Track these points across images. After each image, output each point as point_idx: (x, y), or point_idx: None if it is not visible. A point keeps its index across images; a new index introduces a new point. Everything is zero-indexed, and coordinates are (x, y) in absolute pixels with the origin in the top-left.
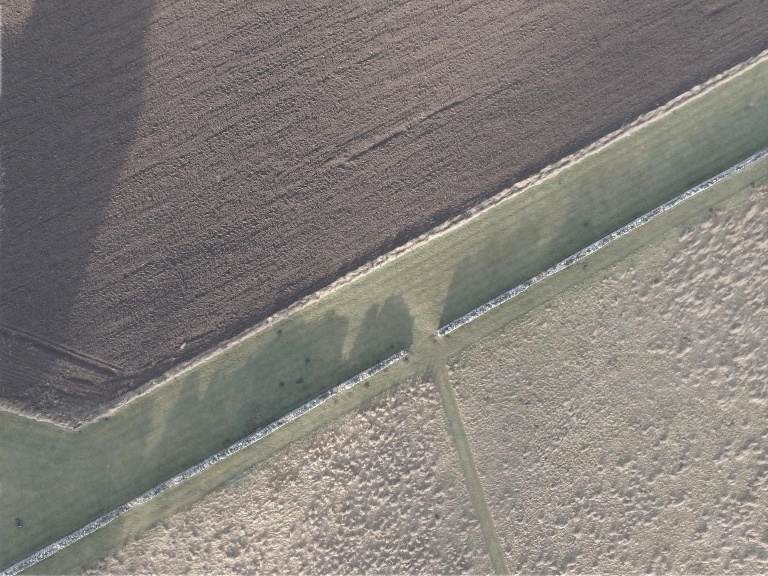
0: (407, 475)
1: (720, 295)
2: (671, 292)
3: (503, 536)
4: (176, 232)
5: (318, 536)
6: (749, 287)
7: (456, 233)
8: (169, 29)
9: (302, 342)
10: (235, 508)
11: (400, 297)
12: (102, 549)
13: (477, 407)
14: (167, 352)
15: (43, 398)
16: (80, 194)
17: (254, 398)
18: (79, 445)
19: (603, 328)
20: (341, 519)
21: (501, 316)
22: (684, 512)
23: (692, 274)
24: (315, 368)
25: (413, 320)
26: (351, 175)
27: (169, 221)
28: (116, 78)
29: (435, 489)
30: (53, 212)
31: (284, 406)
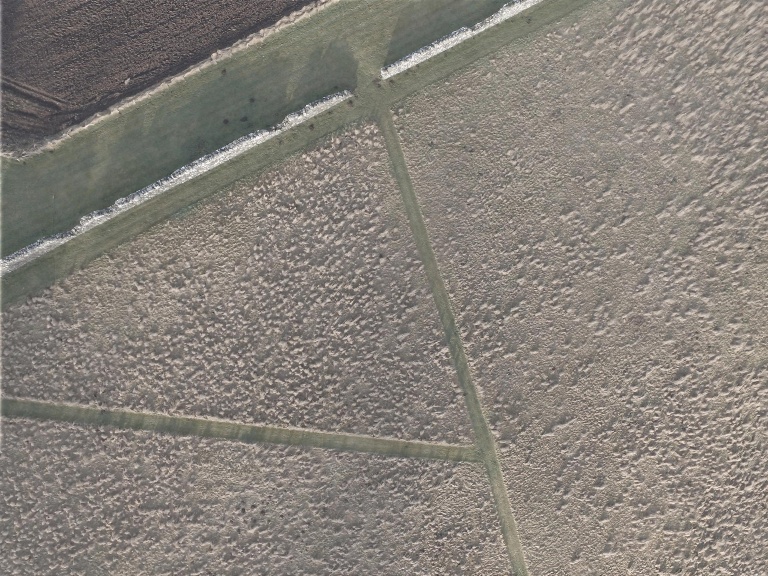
0: (351, 214)
1: (663, 55)
2: (615, 49)
3: (447, 278)
4: None
5: (263, 272)
6: (692, 47)
7: None
8: None
9: (247, 82)
10: (180, 240)
11: (344, 40)
12: (48, 279)
13: (421, 152)
14: (111, 88)
15: None
16: None
17: (198, 134)
18: (24, 176)
19: (547, 81)
20: (286, 256)
21: (446, 65)
22: (626, 265)
23: (636, 32)
24: (260, 107)
25: (357, 64)
26: None
27: None
28: None
29: (379, 230)
30: None
31: (228, 142)
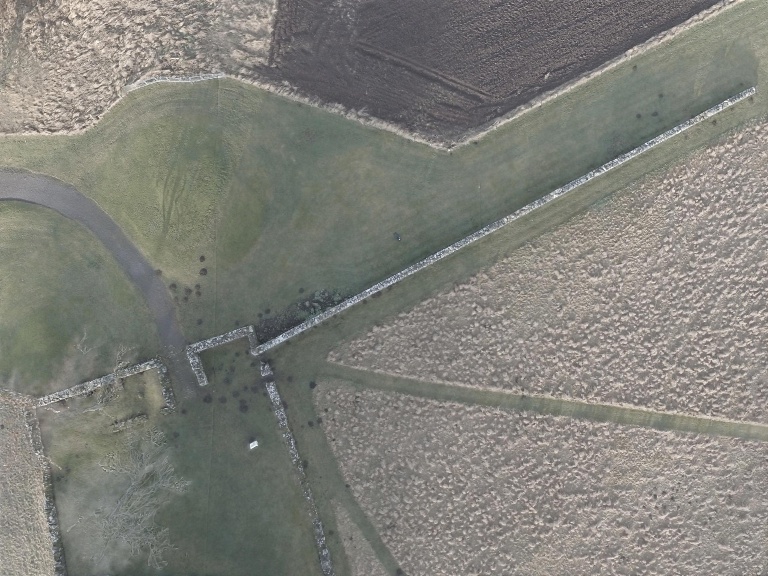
0: (755, 208)
1: None
2: None
3: None
4: None
5: (672, 263)
6: None
7: None
8: None
9: (655, 78)
10: (598, 231)
11: (747, 38)
12: (473, 266)
13: None
14: (531, 82)
15: (416, 120)
16: None
17: (614, 128)
18: (451, 166)
19: None
20: (693, 248)
21: None
22: None
23: None
24: (668, 103)
25: (758, 61)
26: None
27: None
28: None
29: None
30: None
31: (643, 136)
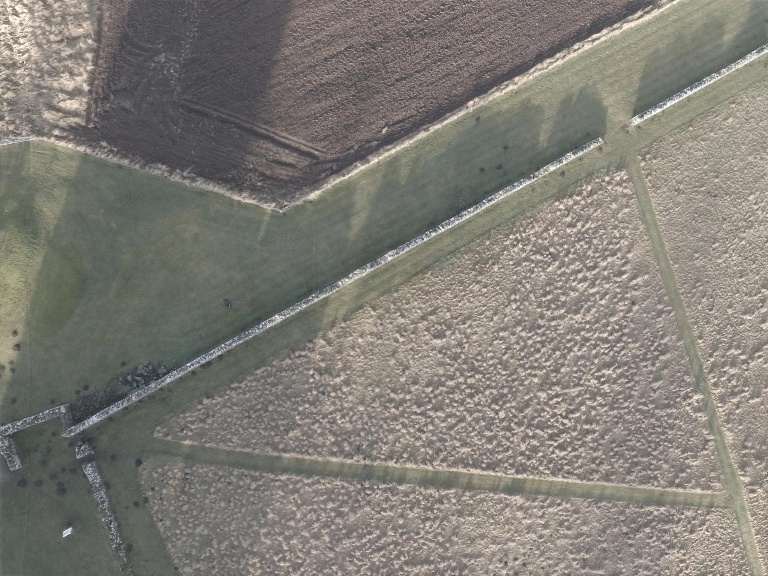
0: (605, 261)
1: None
2: None
3: (695, 324)
4: (375, 16)
5: (520, 321)
6: None
7: (646, 25)
8: None
9: (500, 129)
10: (440, 291)
11: (594, 87)
12: (309, 331)
13: (668, 198)
14: (369, 136)
15: (247, 180)
16: None
17: (456, 183)
18: (284, 227)
19: None
20: (542, 304)
21: (688, 110)
22: None
23: None
24: (514, 155)
25: (607, 110)
26: None
27: (368, 5)
28: None
29: (631, 277)
30: None
31: (486, 190)
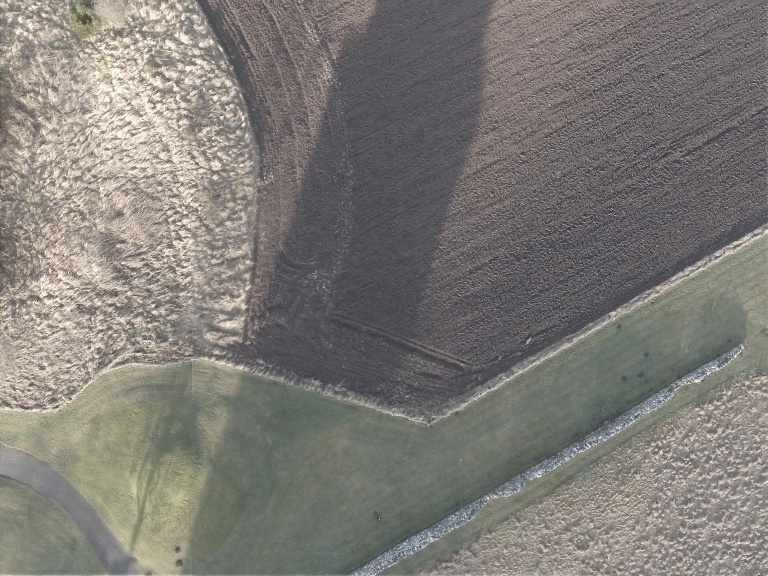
0: (746, 468)
1: None
2: None
3: None
4: (518, 228)
5: (661, 529)
6: None
7: None
8: (508, 27)
9: (641, 336)
10: (584, 501)
11: (734, 291)
12: (455, 542)
13: None
14: (512, 347)
15: (395, 393)
16: (424, 191)
17: (598, 392)
18: (431, 439)
19: None
20: (683, 512)
21: None
22: None
23: None
24: (654, 362)
25: (747, 314)
26: (687, 170)
27: (511, 217)
28: (457, 76)
29: None
30: (399, 209)
31: (628, 400)
